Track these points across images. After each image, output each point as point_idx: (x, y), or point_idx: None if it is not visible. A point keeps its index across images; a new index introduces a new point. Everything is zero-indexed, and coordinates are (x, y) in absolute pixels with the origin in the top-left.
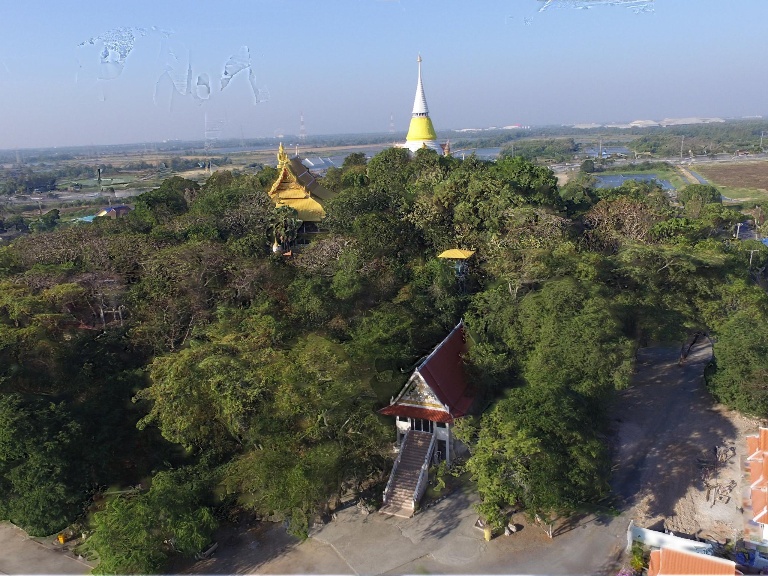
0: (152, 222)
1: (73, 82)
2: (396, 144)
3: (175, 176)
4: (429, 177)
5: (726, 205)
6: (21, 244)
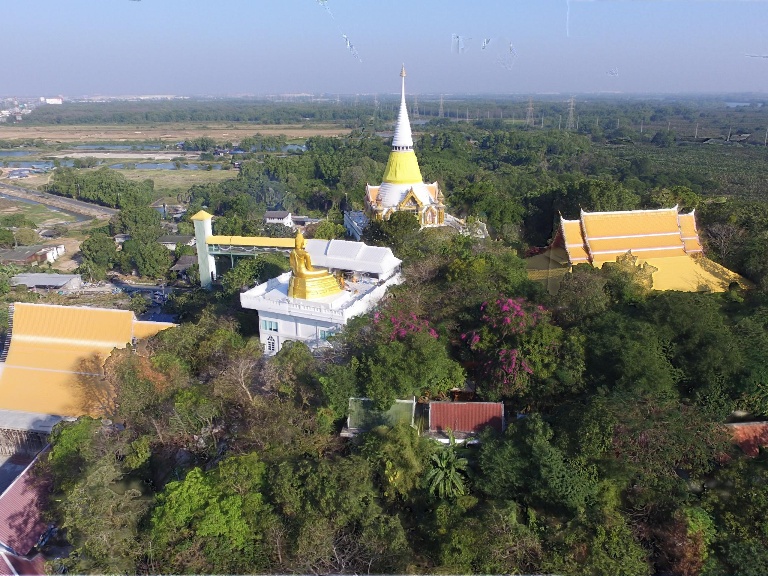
0: None
1: (659, 20)
2: (412, 190)
3: (689, 294)
4: None
5: None
6: None
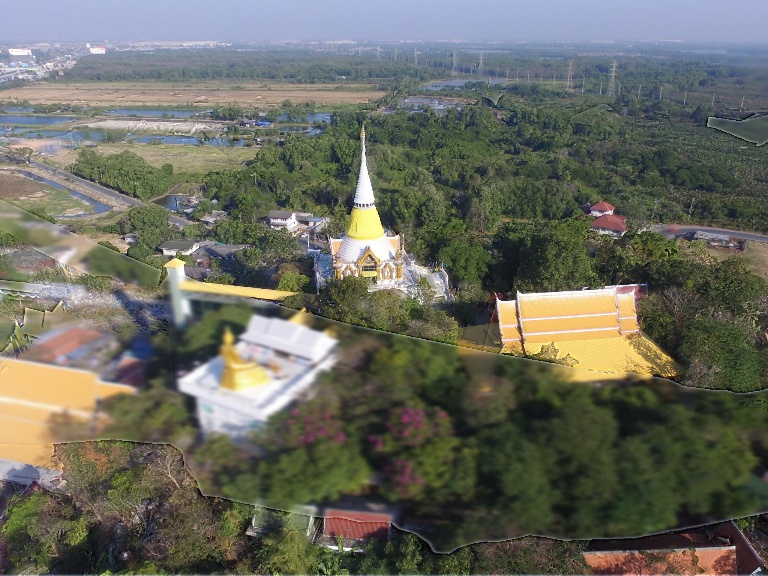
0: None
1: None
2: None
3: None
4: None
5: (115, 222)
6: None
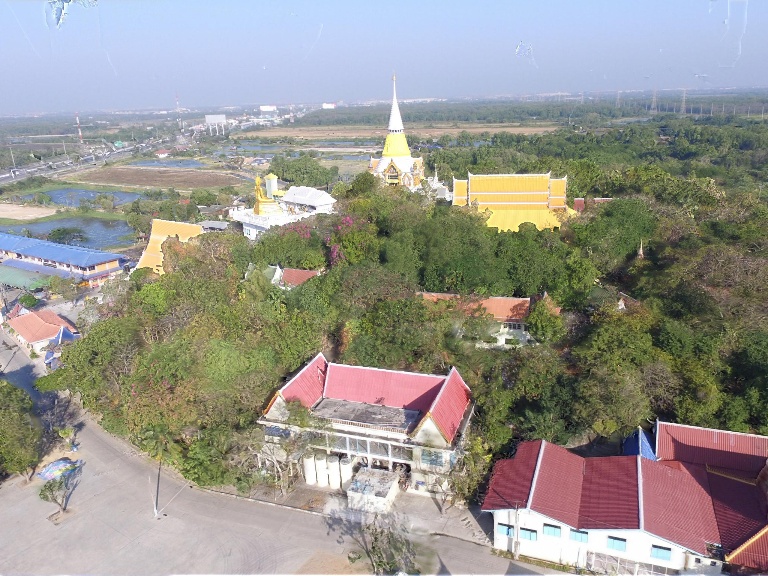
0: (690, 233)
1: None
2: None
3: None
4: (608, 174)
5: None
6: (763, 272)
